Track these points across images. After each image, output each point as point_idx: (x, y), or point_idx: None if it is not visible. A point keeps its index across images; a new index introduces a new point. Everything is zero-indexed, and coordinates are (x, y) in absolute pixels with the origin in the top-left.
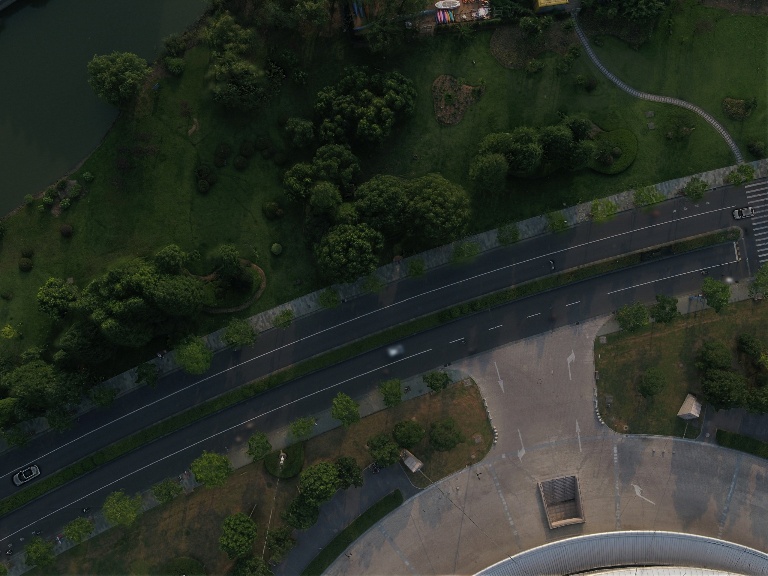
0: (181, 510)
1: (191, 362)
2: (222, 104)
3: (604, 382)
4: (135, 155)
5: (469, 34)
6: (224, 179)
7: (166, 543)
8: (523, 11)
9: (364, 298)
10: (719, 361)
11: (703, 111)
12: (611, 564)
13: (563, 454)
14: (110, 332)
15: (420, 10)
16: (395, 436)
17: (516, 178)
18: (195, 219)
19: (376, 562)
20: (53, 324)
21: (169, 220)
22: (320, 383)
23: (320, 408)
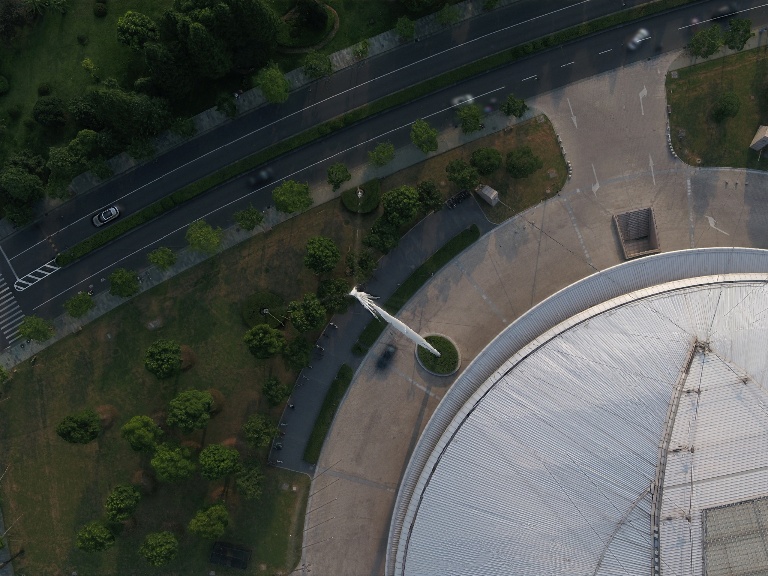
0: (260, 248)
1: (272, 85)
2: None
3: (676, 116)
4: None
5: None
6: None
7: (246, 280)
8: None
9: (437, 37)
10: None
11: None
12: None
13: (637, 187)
14: (196, 39)
15: None
16: (473, 162)
17: None
18: None
19: (454, 297)
20: (129, 67)
21: None
22: (395, 122)
23: (395, 146)
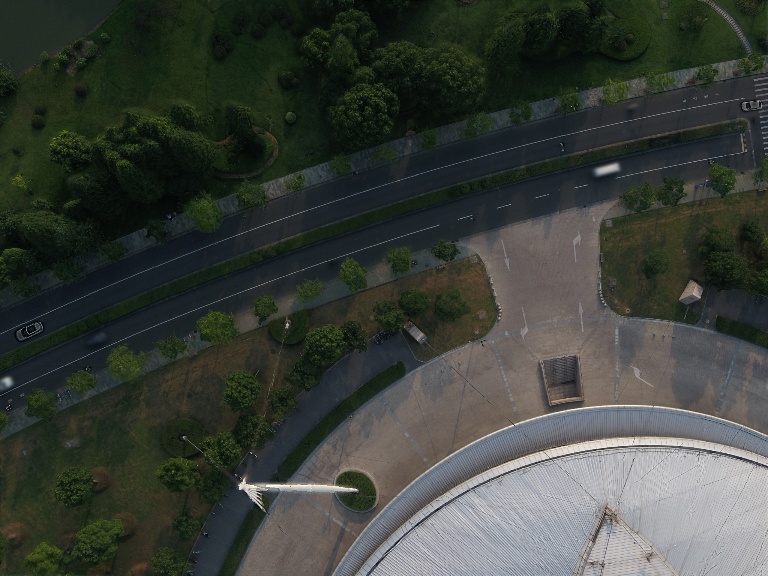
0: (184, 373)
1: (202, 217)
2: None
3: (608, 265)
4: (153, 19)
5: None
6: (241, 47)
7: (167, 404)
8: None
9: (375, 171)
10: (723, 243)
11: (716, 4)
12: (609, 437)
13: (565, 334)
14: (124, 175)
15: None
16: (401, 303)
17: (530, 60)
18: (211, 85)
19: (376, 433)
20: (63, 182)
21: (185, 85)
22: (328, 253)
23: (327, 278)
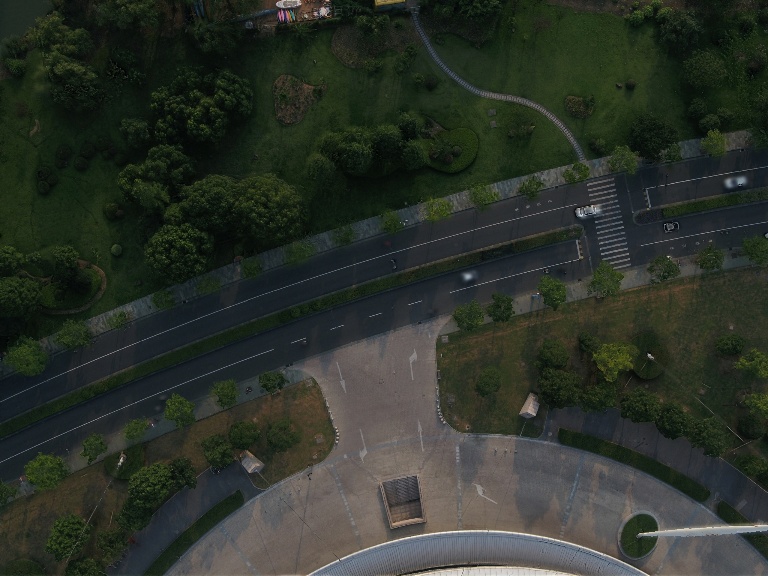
0: (22, 512)
1: (21, 364)
2: (62, 105)
3: (446, 381)
4: None
5: (308, 33)
6: (65, 180)
7: (6, 545)
8: (362, 10)
9: (205, 299)
10: (554, 360)
11: (545, 109)
12: (444, 564)
13: (405, 454)
14: None
15: (261, 10)
16: (230, 437)
17: (357, 177)
18: (36, 220)
19: (218, 563)
20: None
21: (10, 222)
22: (161, 384)
23: (161, 409)
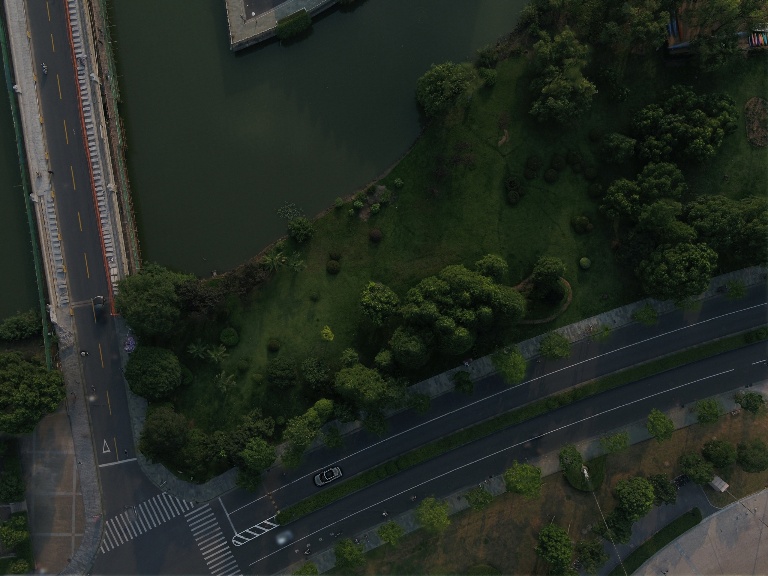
0: (480, 518)
1: (515, 372)
2: (535, 117)
3: None
4: None
5: None
6: (533, 191)
7: (464, 550)
8: None
9: (669, 316)
10: None
11: None
12: None
13: None
14: (457, 340)
15: (735, 32)
16: (707, 455)
17: None
18: (503, 229)
19: None
20: (359, 327)
21: (477, 229)
22: (622, 398)
23: (621, 423)
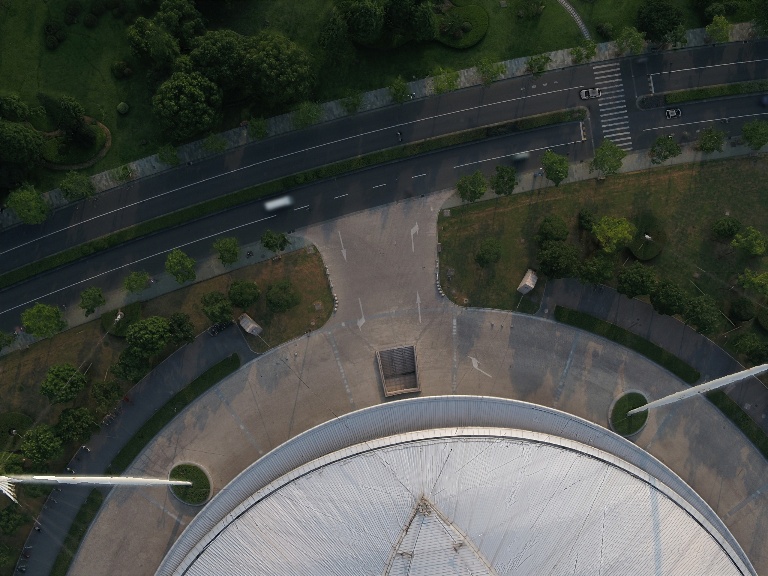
0: (15, 366)
1: (22, 209)
2: None
3: (446, 255)
4: None
5: None
6: (74, 37)
7: None
8: None
9: (210, 161)
10: (554, 232)
11: None
12: (438, 427)
13: (402, 324)
14: None
15: None
16: (230, 295)
17: (367, 49)
18: (42, 75)
19: (211, 425)
20: None
21: (16, 75)
22: (162, 245)
23: (161, 270)
